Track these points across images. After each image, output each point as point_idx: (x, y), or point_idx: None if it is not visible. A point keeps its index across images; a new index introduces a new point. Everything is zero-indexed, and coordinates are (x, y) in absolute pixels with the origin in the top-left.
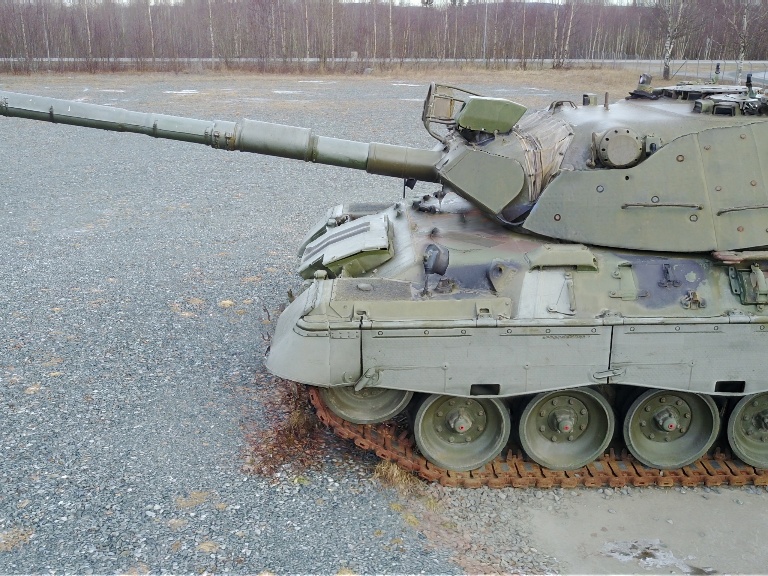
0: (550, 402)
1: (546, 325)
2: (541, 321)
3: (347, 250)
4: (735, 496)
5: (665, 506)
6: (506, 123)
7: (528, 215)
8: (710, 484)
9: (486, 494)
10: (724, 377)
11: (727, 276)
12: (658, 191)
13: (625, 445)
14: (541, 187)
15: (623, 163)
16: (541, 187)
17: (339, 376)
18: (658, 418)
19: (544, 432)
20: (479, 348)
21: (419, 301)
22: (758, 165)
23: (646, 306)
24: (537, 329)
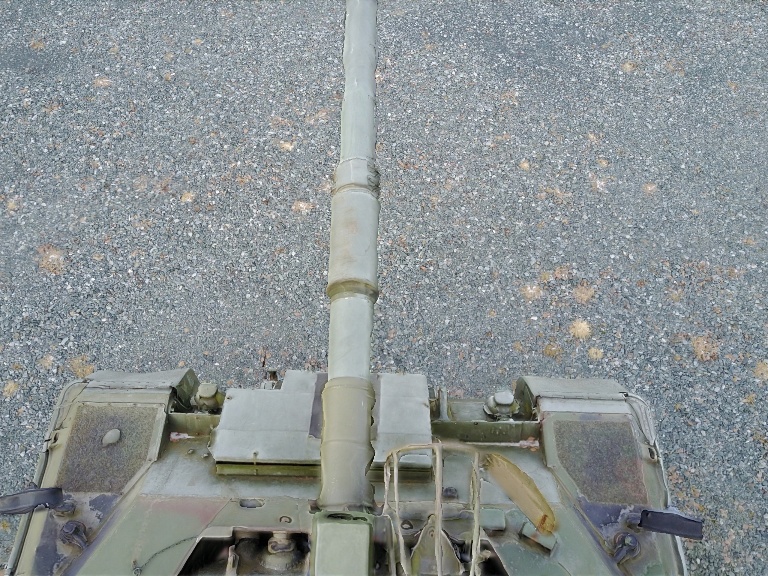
0: None
1: None
2: None
3: (238, 411)
4: None
5: None
6: None
7: None
8: None
9: None
10: None
11: None
12: None
13: None
14: None
15: None
16: None
17: None
18: None
19: None
20: None
21: None
22: None
23: None
24: None
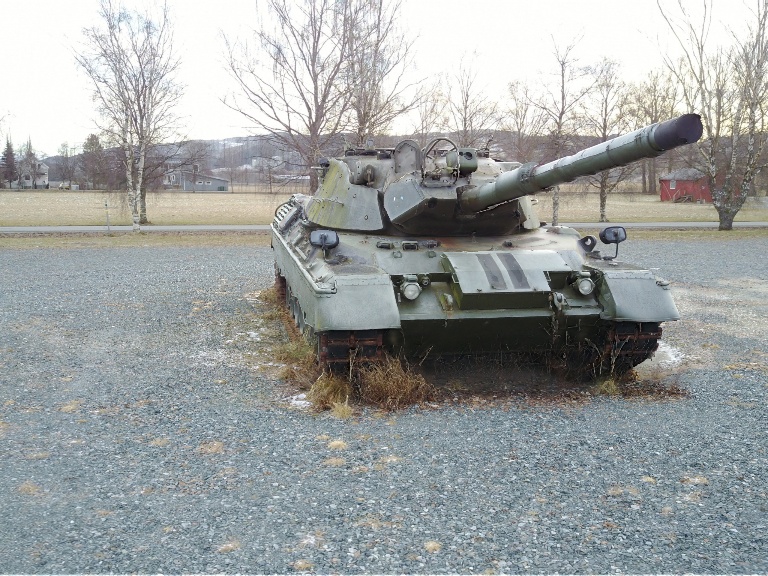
0: None
1: None
2: None
3: (556, 260)
4: None
5: None
6: None
7: None
8: None
9: None
10: None
11: None
12: None
13: None
14: None
15: None
16: None
17: None
18: None
19: None
20: None
21: None
22: None
23: None
24: None
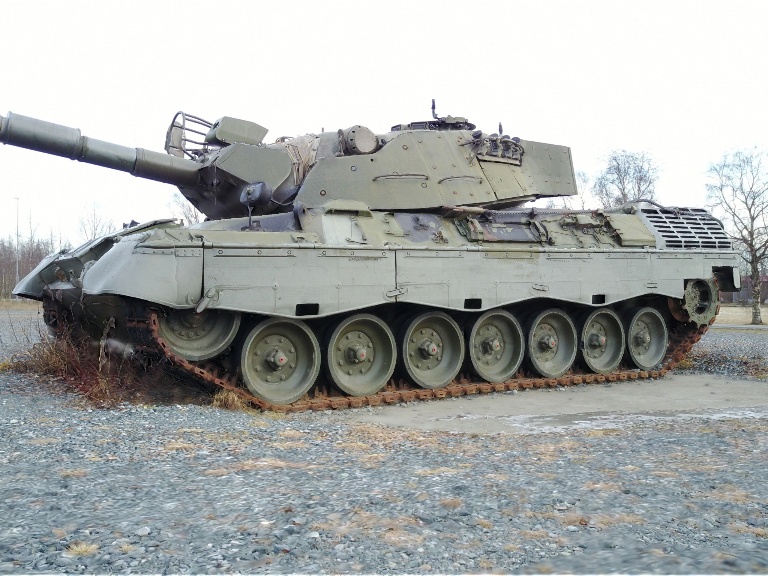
0: (345, 337)
1: (351, 248)
2: (347, 245)
3: None
4: (488, 397)
5: (449, 405)
6: (254, 140)
7: (296, 195)
8: (469, 392)
9: (314, 413)
10: (469, 295)
11: (454, 225)
12: (396, 168)
13: (405, 369)
14: (303, 174)
15: (366, 151)
16: (303, 174)
17: (183, 296)
18: (423, 347)
19: (342, 366)
20: (302, 269)
21: (245, 232)
22: (453, 155)
23: (412, 241)
24: (345, 251)
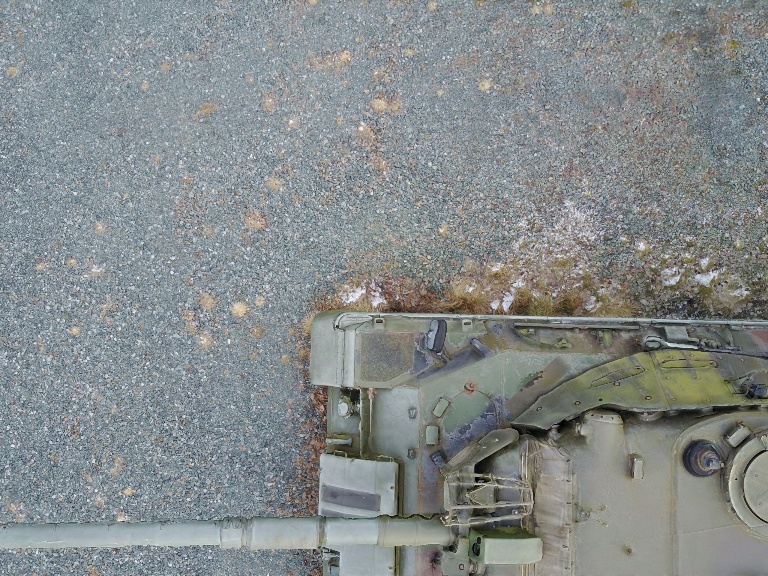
0: None
1: None
2: None
3: None
4: None
5: None
6: None
7: None
8: None
9: None
10: None
11: None
12: None
13: None
14: None
15: None
16: None
17: None
18: None
19: None
20: None
21: None
22: None
23: None
24: None
